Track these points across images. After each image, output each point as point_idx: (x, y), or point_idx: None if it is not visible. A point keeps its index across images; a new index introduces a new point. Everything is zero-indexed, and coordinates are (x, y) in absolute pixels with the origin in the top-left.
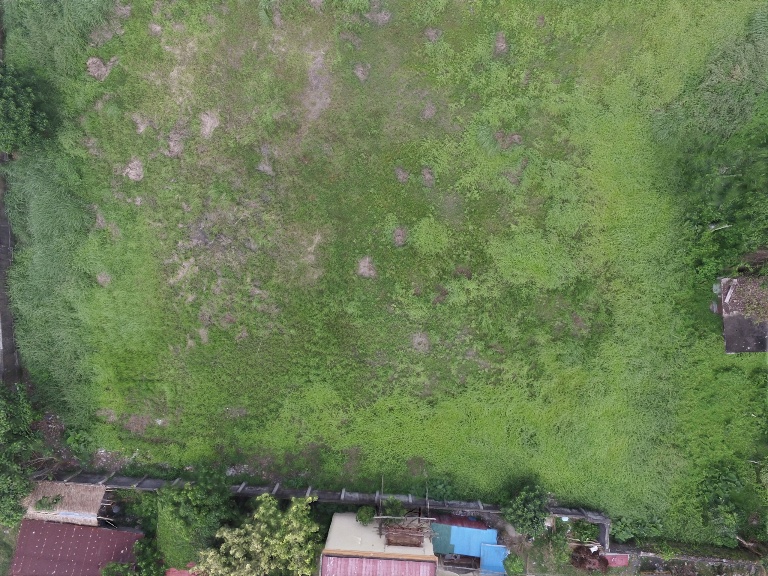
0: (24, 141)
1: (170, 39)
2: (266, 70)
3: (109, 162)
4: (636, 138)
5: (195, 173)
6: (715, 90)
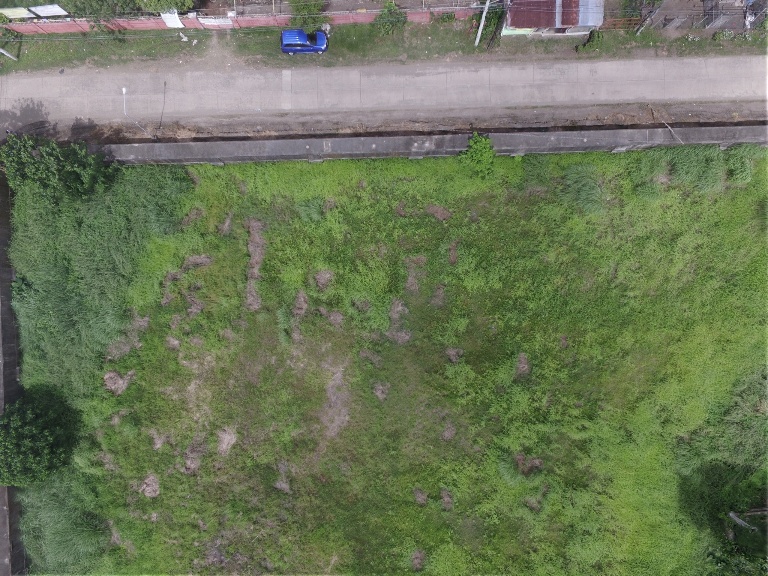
0: None
1: (188, 353)
2: (284, 387)
3: (125, 477)
4: (659, 468)
5: (212, 490)
6: (740, 422)
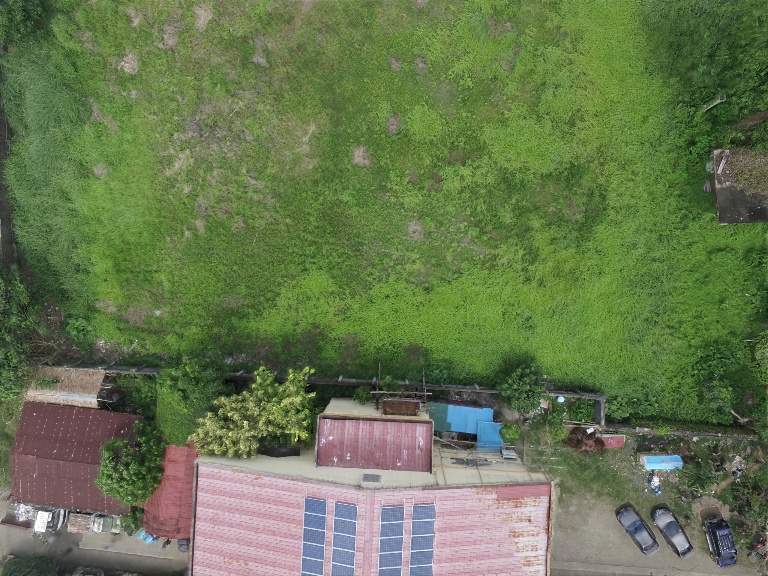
0: (19, 29)
1: None
2: None
3: (104, 56)
4: (628, 22)
5: (189, 66)
6: None
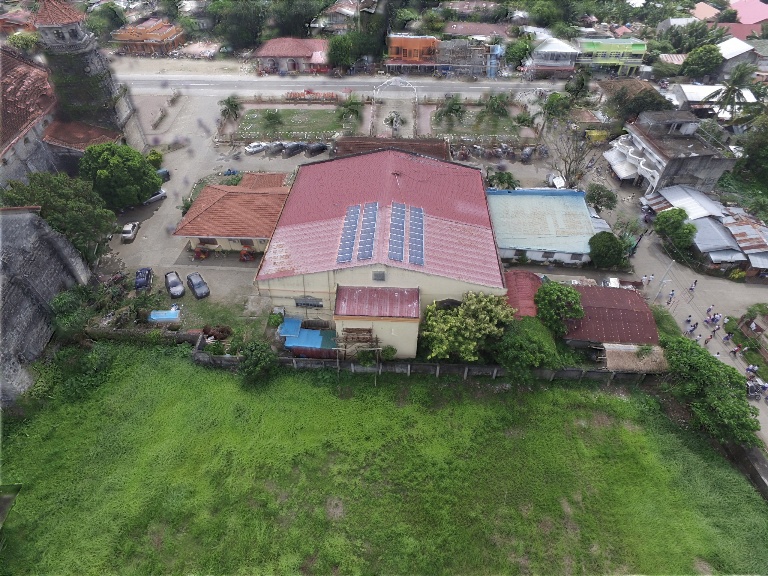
0: None
1: None
2: None
3: None
4: None
5: None
6: None
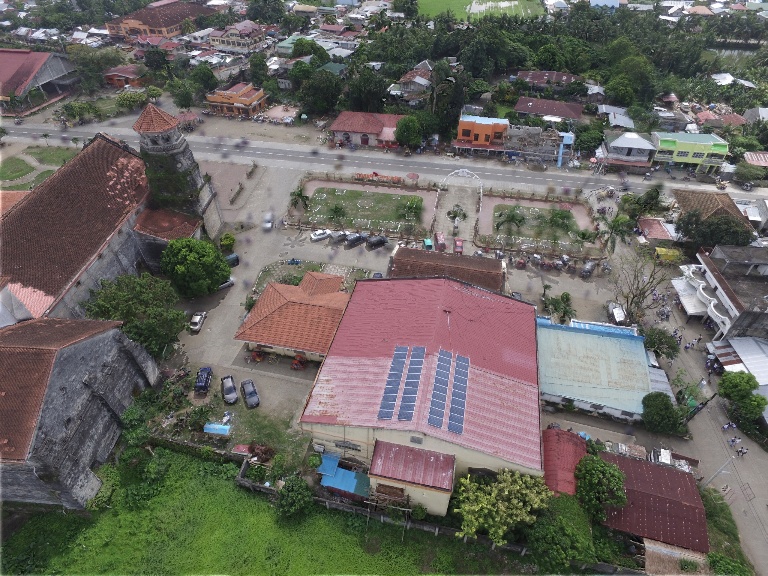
0: None
1: None
2: None
3: None
4: None
5: None
6: None
